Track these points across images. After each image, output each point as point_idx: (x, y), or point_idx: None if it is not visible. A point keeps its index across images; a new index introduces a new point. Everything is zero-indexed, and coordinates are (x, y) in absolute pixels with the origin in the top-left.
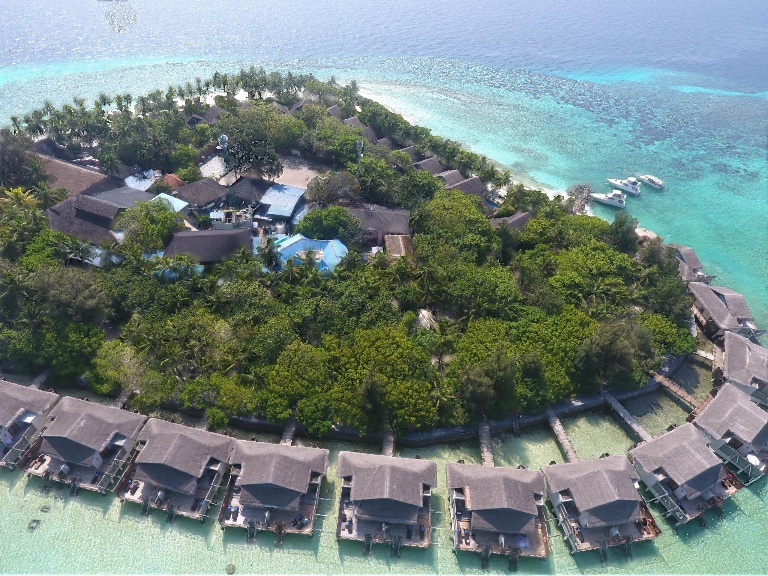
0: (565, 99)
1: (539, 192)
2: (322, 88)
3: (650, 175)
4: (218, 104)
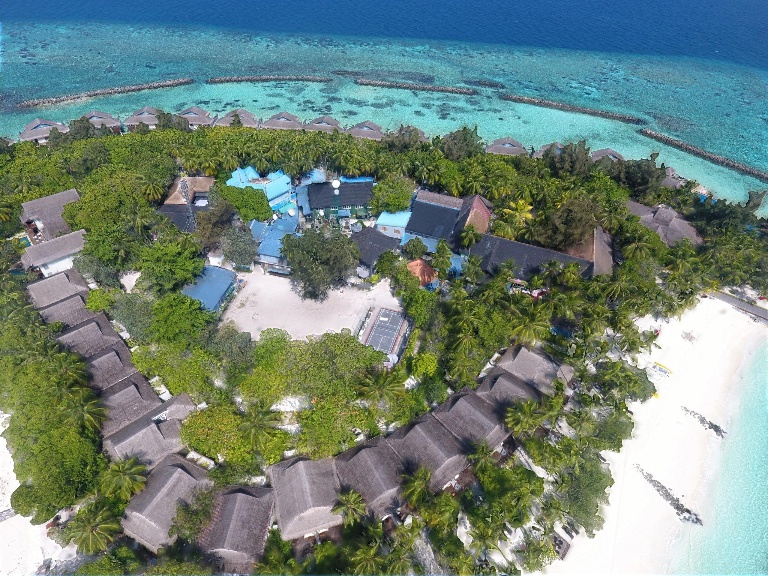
0: None
1: None
2: (163, 568)
3: None
4: (449, 493)
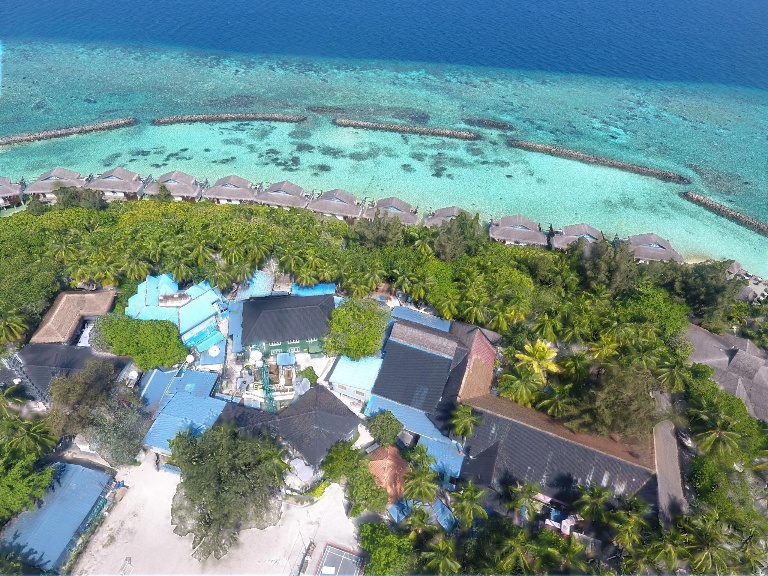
0: None
1: None
2: None
3: None
4: None
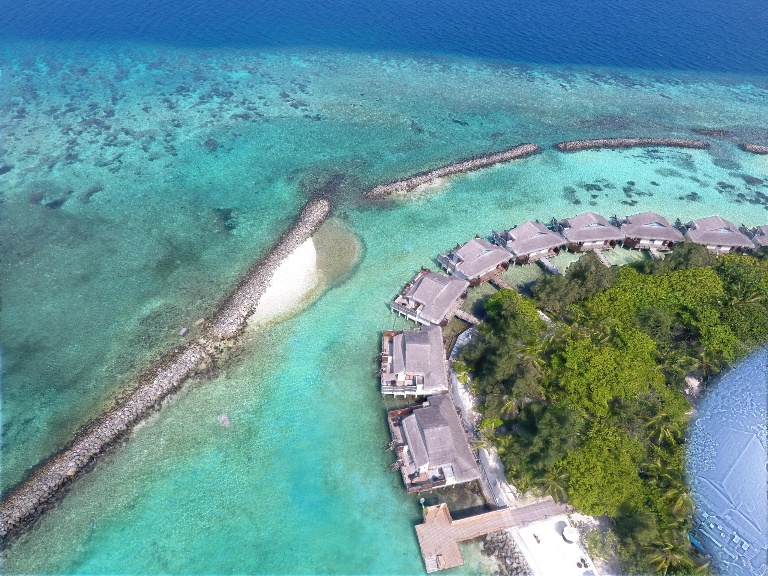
0: None
1: None
2: None
3: None
4: None
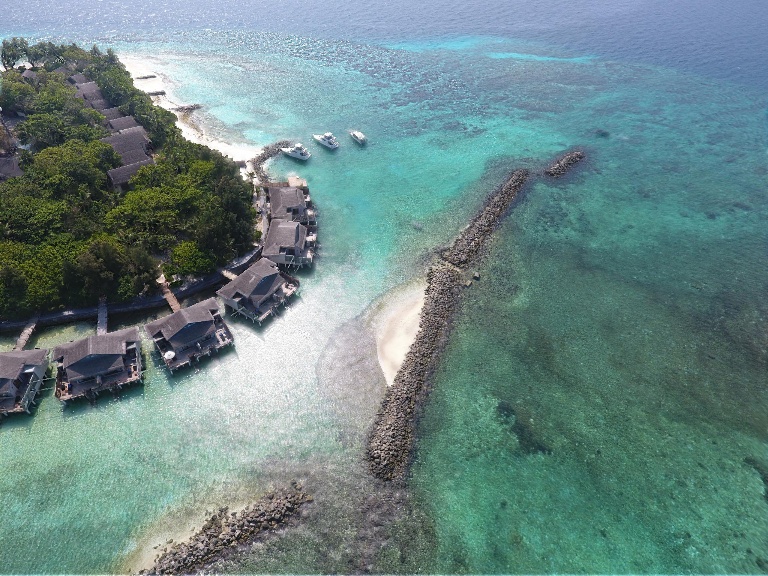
0: (357, 66)
1: (180, 142)
2: (77, 56)
3: (370, 132)
4: None
